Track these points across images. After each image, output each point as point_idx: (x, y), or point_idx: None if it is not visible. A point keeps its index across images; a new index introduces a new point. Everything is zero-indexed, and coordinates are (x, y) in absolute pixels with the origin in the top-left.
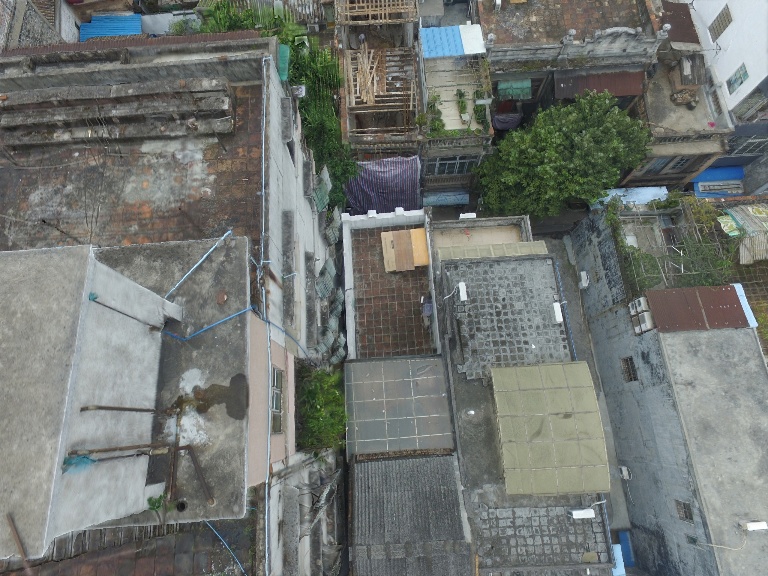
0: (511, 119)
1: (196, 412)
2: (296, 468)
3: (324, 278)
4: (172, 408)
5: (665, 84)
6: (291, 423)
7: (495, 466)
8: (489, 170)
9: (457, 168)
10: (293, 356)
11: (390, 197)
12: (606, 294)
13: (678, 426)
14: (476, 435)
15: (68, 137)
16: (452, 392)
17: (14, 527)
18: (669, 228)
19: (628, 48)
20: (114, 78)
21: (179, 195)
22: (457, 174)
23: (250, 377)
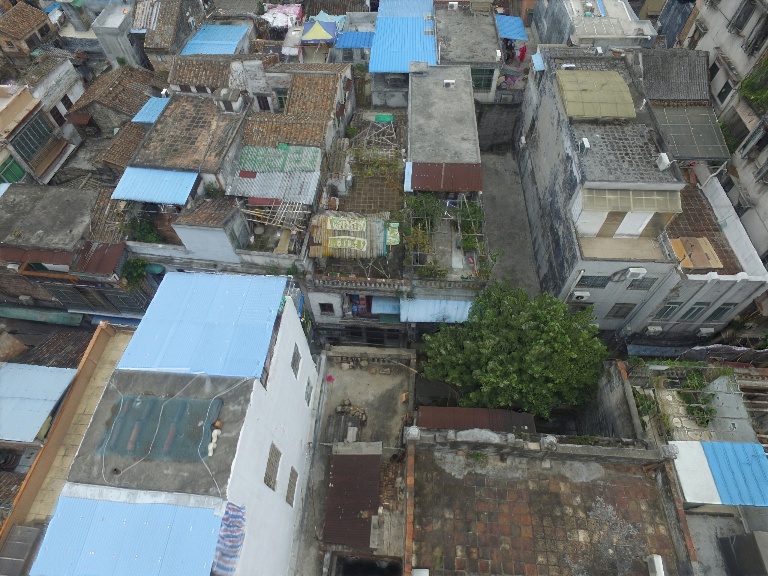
0: None
1: None
2: None
3: None
4: None
5: None
6: None
7: None
8: None
9: None
10: None
11: None
12: None
13: None
14: None
15: None
16: None
17: None
18: None
19: None
20: None
21: None
22: None
23: None
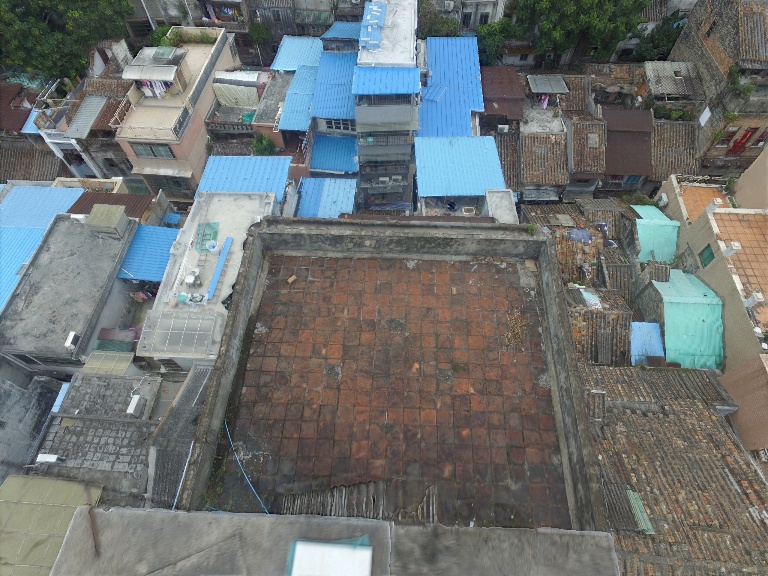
0: None
1: None
2: None
3: None
4: None
5: None
6: None
7: None
8: None
9: None
10: None
11: None
12: None
13: None
14: None
15: None
16: None
17: (95, 539)
18: None
19: None
20: None
21: None
22: None
23: None
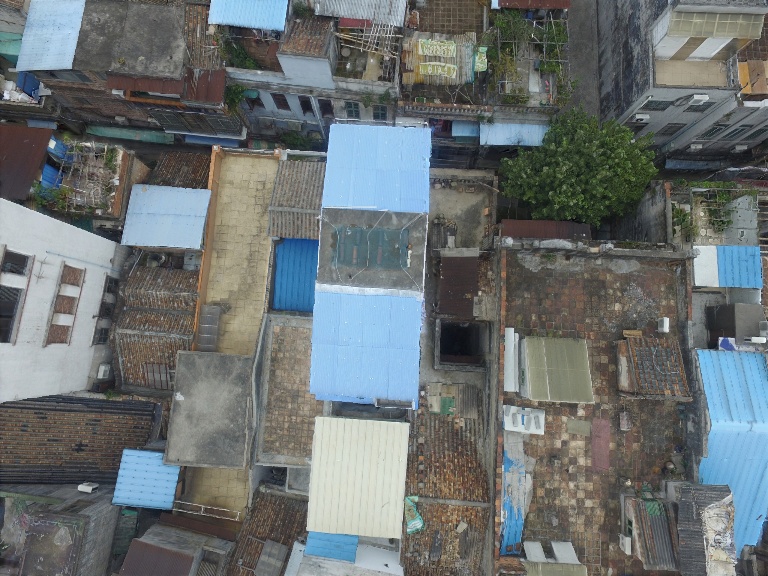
0: None
1: None
2: None
3: None
4: None
5: None
6: None
7: None
8: None
9: None
10: None
11: None
12: None
13: None
14: None
15: None
16: None
17: None
18: None
19: None
20: None
21: None
22: None
23: None
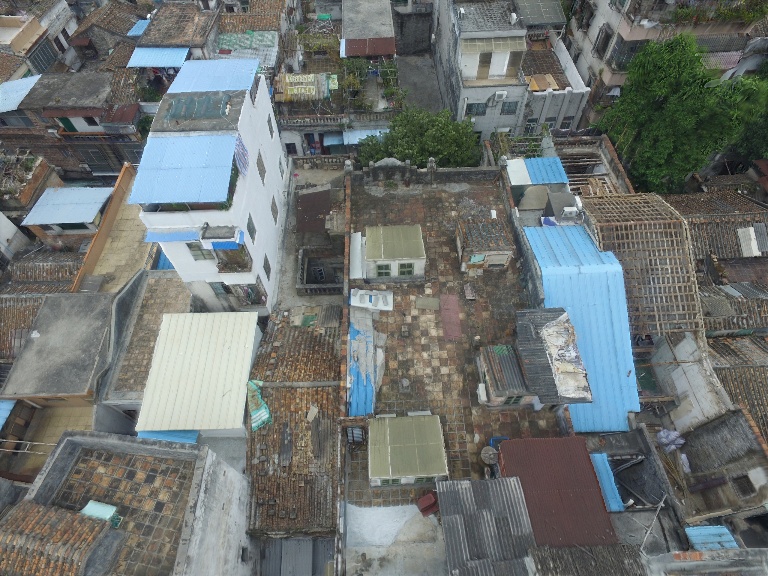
0: None
1: None
2: None
3: None
4: None
5: None
6: None
7: None
8: None
9: None
10: None
11: None
12: None
13: None
14: None
15: None
16: None
17: None
18: None
19: None
20: None
21: None
22: None
23: None
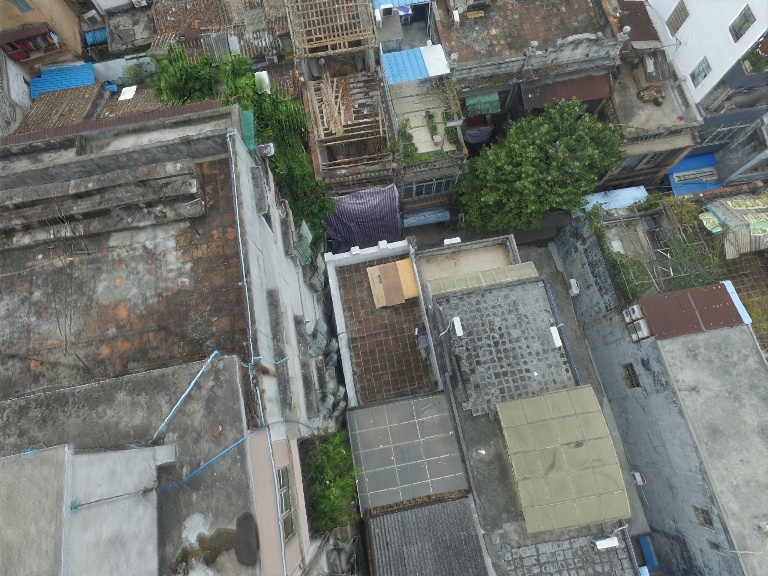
0: (482, 132)
1: (203, 563)
2: (313, 560)
3: (316, 340)
4: (177, 563)
5: (630, 82)
6: (303, 516)
7: (512, 503)
8: (467, 189)
9: (434, 188)
10: (296, 440)
11: (370, 225)
12: (598, 301)
13: (687, 433)
14: (489, 473)
15: (29, 240)
16: (460, 432)
17: None
18: (652, 228)
19: (591, 53)
20: (71, 170)
21: (155, 289)
22: (435, 194)
23: (257, 508)
